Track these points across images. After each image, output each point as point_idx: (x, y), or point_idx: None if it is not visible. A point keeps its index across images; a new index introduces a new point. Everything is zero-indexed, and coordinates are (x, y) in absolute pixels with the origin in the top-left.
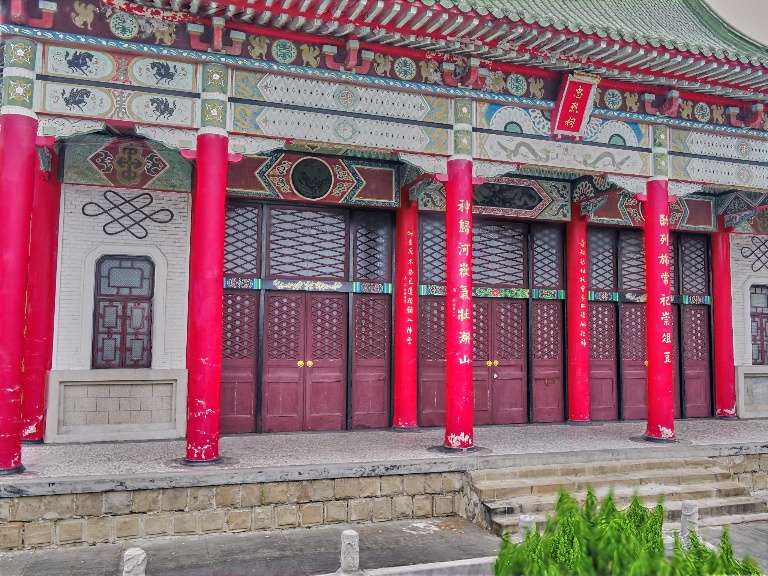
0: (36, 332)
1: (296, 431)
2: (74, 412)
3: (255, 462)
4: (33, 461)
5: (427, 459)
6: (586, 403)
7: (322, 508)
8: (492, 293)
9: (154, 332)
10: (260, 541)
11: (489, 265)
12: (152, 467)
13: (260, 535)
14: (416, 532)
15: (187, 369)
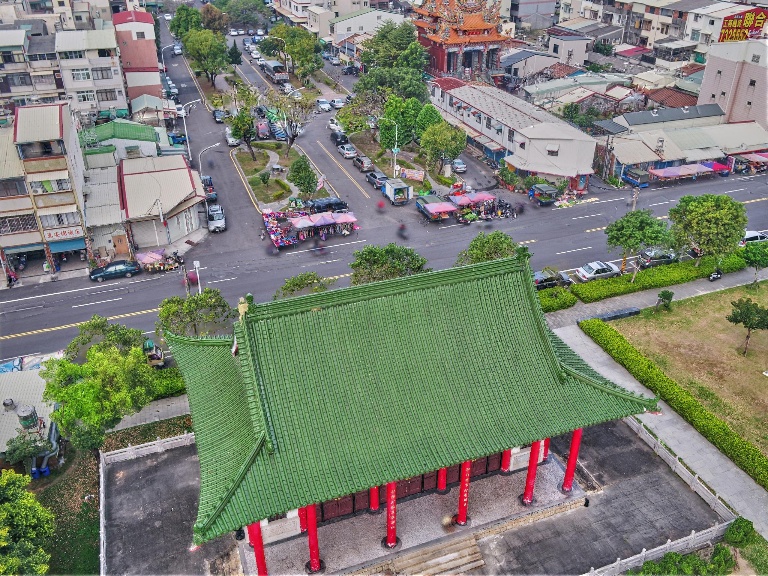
0: None
1: (336, 517)
2: (265, 535)
3: None
4: (267, 571)
5: (381, 558)
6: (444, 485)
7: None
8: None
9: None
10: None
11: None
12: (303, 575)
13: None
14: None
15: (299, 516)
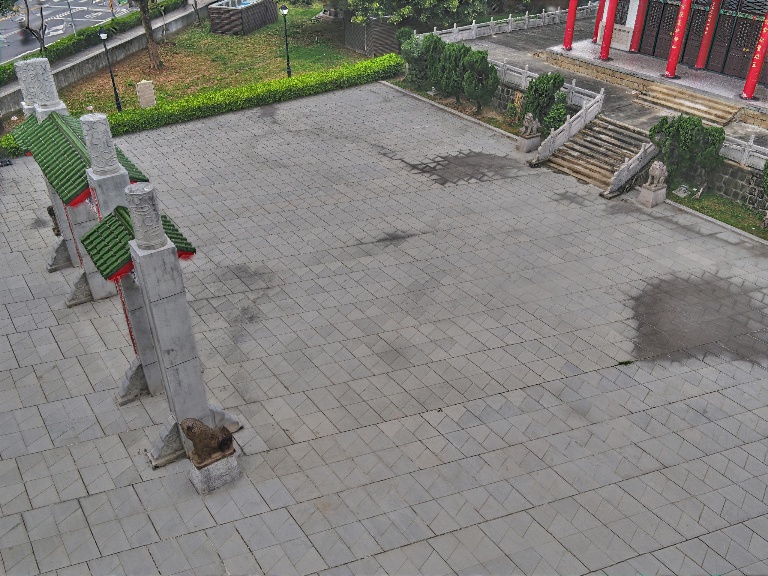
0: (600, 9)
1: (664, 58)
2: None
3: None
4: None
5: (648, 75)
6: None
7: None
8: (753, 17)
9: (628, 14)
10: (596, 81)
11: (757, 3)
12: None
13: None
14: (627, 92)
15: None
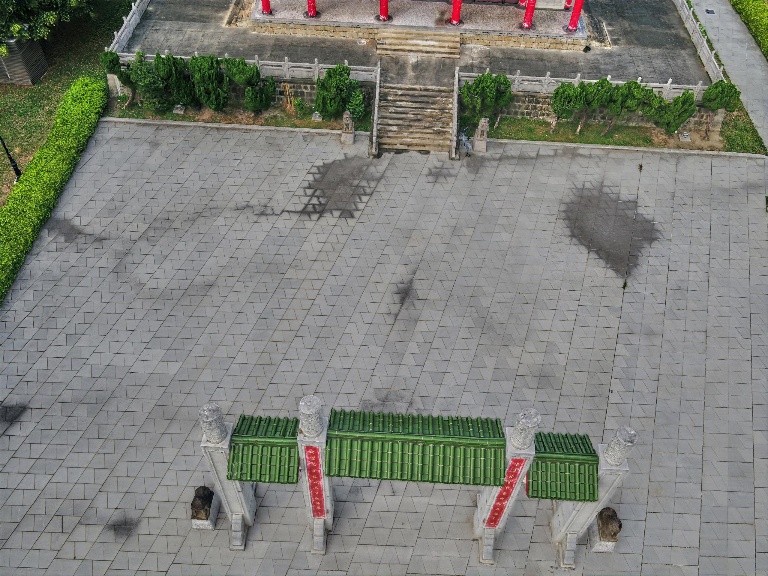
0: None
1: None
2: None
3: (325, 18)
4: (273, 7)
5: (369, 24)
6: None
7: (339, 33)
8: None
9: None
10: (322, 40)
11: None
12: (300, 16)
13: (324, 38)
14: (359, 44)
15: None
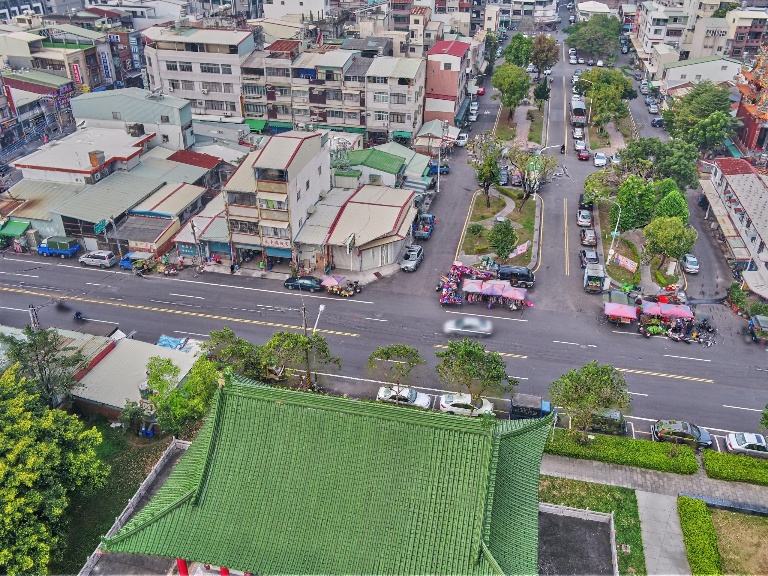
0: None
1: None
2: None
3: None
4: None
5: None
6: None
7: None
8: None
9: None
10: None
11: None
12: None
13: None
14: None
15: None
